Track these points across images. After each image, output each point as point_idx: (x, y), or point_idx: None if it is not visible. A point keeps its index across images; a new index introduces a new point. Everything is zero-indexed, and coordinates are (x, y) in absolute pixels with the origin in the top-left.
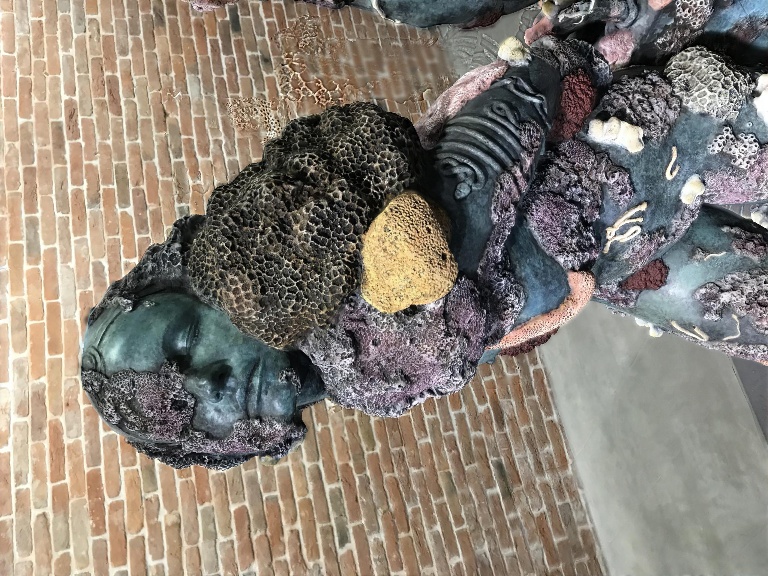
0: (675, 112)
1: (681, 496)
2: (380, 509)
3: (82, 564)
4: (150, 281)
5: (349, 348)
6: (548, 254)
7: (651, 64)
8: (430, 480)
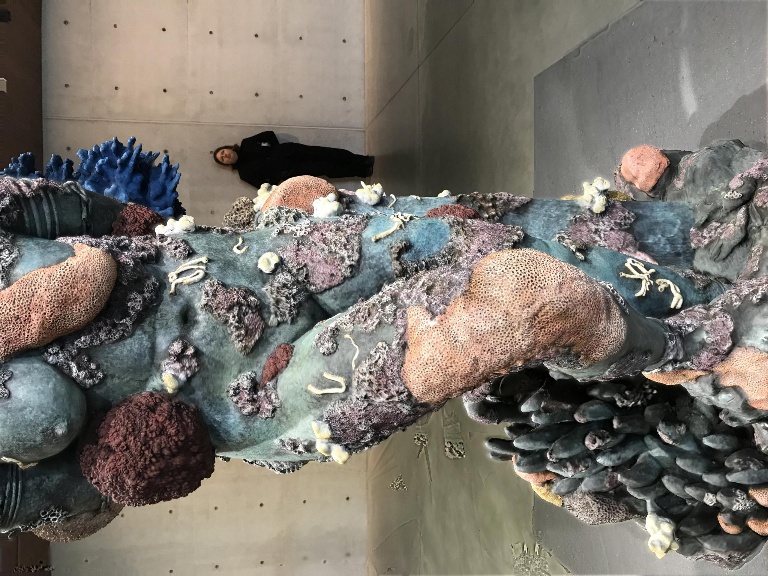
0: None
1: None
2: None
3: None
4: None
5: None
6: None
7: None
8: None
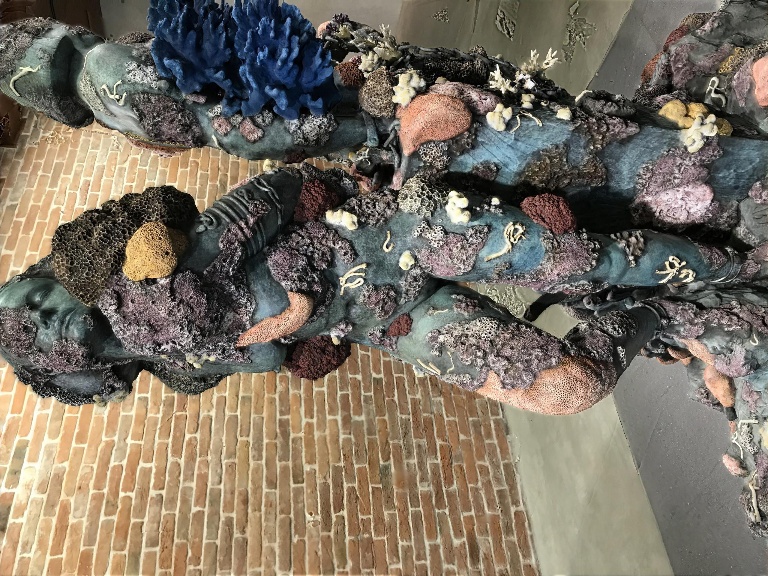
0: (392, 211)
1: None
2: None
3: None
4: (38, 272)
5: (114, 300)
6: (276, 280)
7: None
8: None
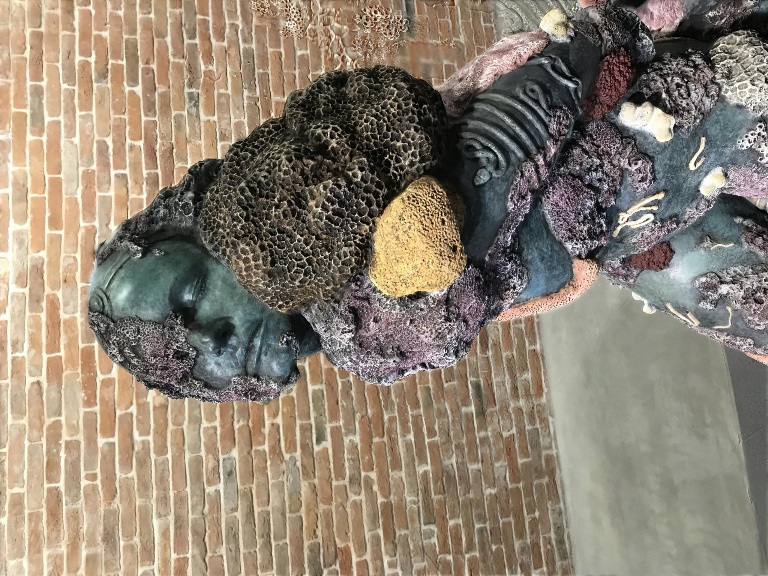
0: (712, 101)
1: (644, 437)
2: (359, 414)
3: (72, 432)
4: (160, 227)
5: (350, 324)
6: (557, 239)
7: (698, 36)
8: (409, 392)
